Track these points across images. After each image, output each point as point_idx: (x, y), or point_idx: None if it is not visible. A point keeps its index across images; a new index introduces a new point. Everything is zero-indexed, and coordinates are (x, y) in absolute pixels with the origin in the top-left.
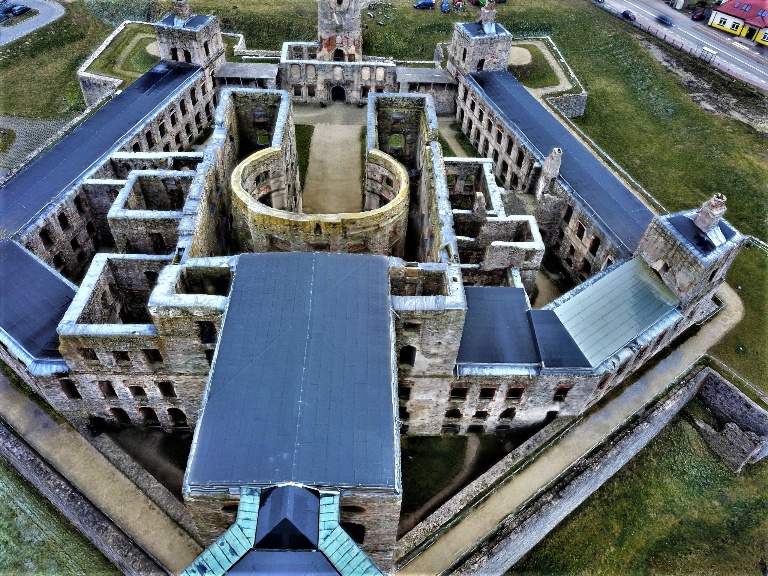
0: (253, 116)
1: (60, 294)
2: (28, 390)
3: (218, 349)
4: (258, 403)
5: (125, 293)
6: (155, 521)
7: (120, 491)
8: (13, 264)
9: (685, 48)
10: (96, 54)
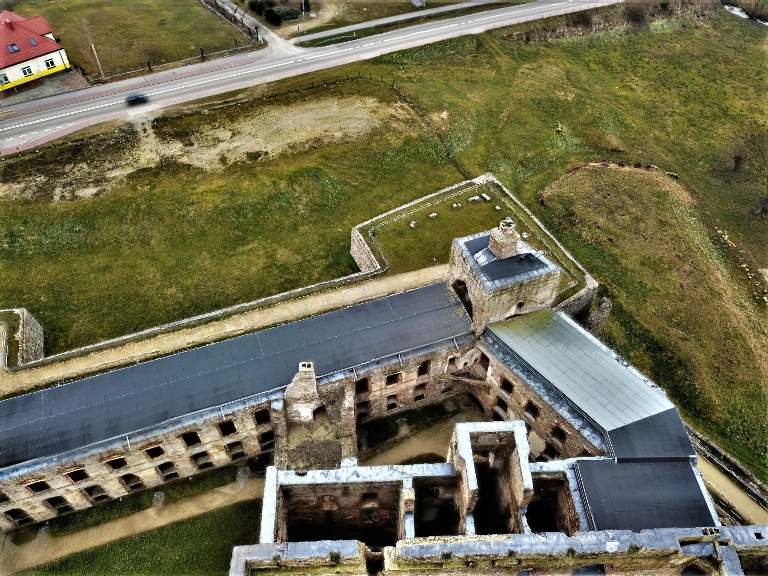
0: None
1: None
2: None
3: None
4: None
5: None
6: None
7: None
8: None
9: None
10: None
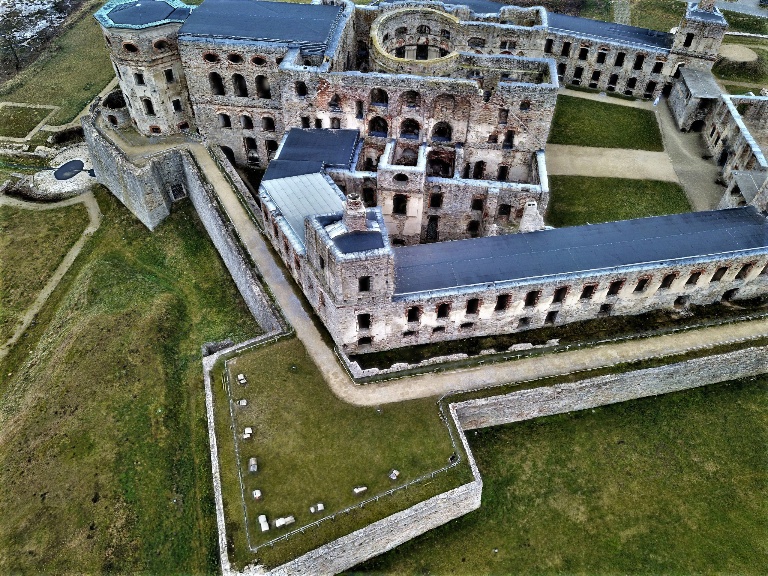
0: None
1: None
2: None
3: None
4: (238, 7)
5: None
6: None
7: None
8: None
9: None
10: None
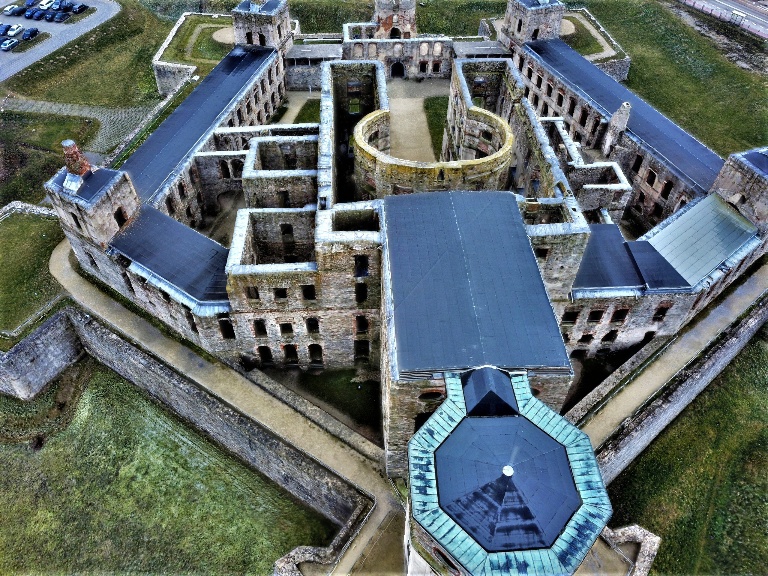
0: (347, 86)
1: (206, 248)
2: (178, 337)
3: (390, 271)
4: (438, 310)
5: (259, 246)
6: (318, 437)
7: (281, 415)
8: (157, 225)
9: (714, 13)
10: (165, 44)
